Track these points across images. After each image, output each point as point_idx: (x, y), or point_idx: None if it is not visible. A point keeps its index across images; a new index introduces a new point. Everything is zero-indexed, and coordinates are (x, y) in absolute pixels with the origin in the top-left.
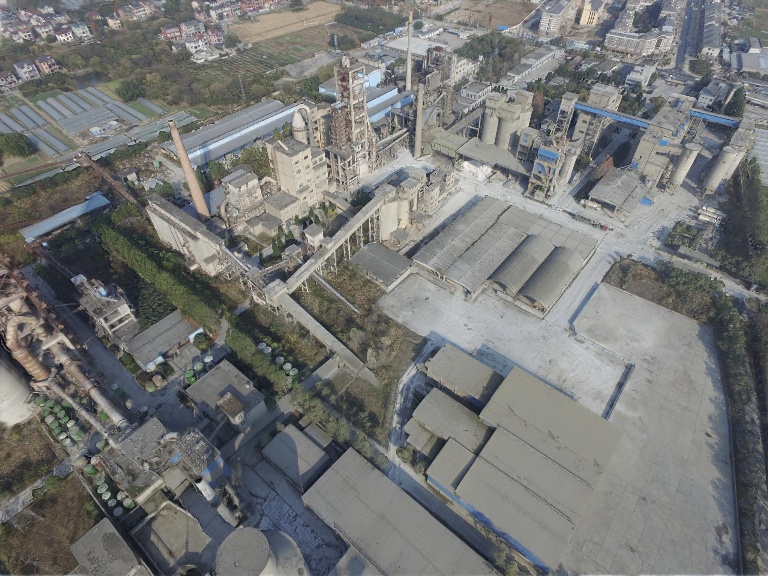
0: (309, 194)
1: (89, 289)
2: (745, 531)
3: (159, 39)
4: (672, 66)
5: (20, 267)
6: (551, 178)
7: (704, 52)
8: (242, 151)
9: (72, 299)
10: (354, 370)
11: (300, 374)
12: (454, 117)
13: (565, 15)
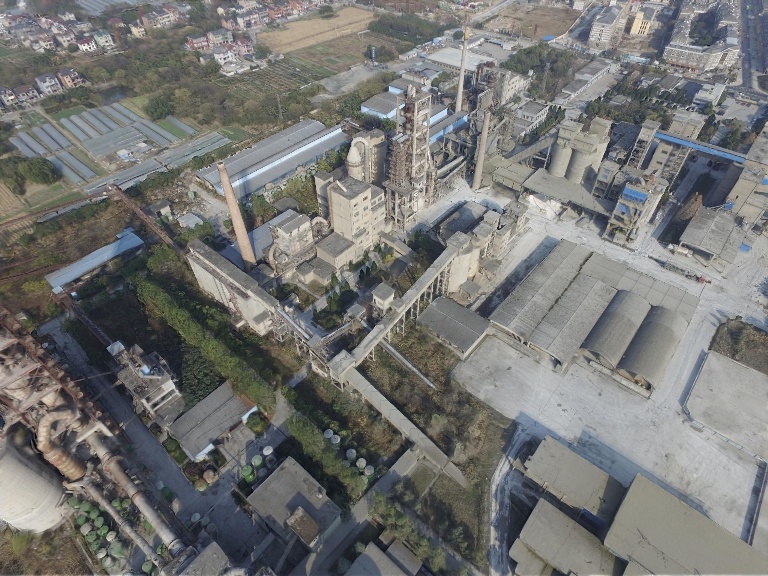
0: (365, 237)
1: (129, 364)
2: None
3: (185, 49)
4: (739, 82)
5: (46, 321)
6: (636, 220)
7: None
8: (284, 181)
9: (106, 365)
10: (437, 465)
11: (376, 472)
12: (514, 143)
13: (616, 24)
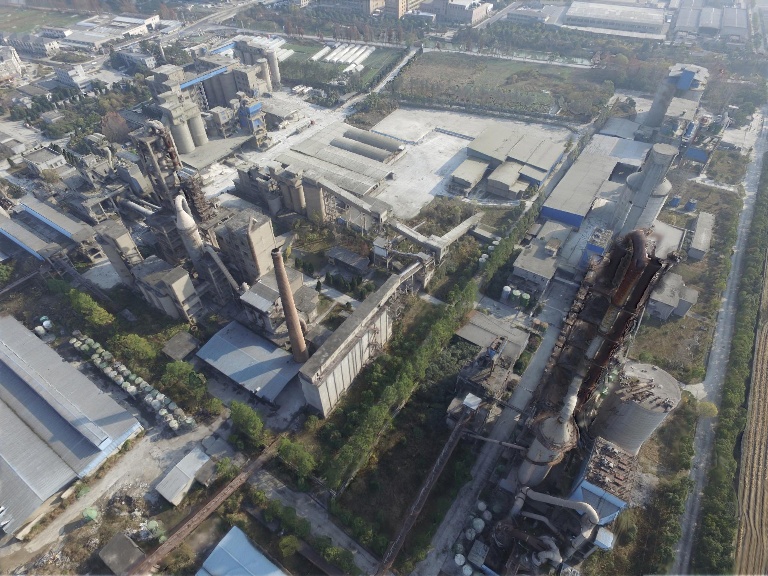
0: None
1: None
2: (515, 116)
3: None
4: None
5: None
6: None
7: (50, 48)
8: None
9: (468, 453)
10: None
11: None
12: None
13: None
